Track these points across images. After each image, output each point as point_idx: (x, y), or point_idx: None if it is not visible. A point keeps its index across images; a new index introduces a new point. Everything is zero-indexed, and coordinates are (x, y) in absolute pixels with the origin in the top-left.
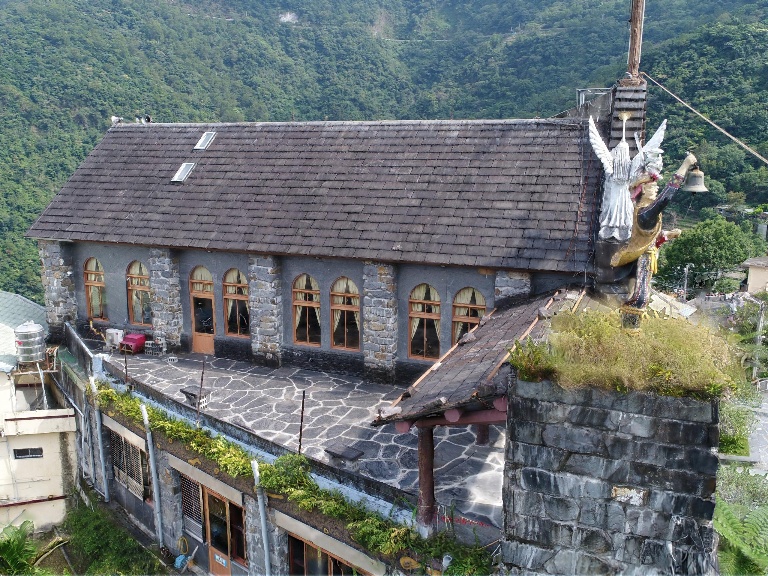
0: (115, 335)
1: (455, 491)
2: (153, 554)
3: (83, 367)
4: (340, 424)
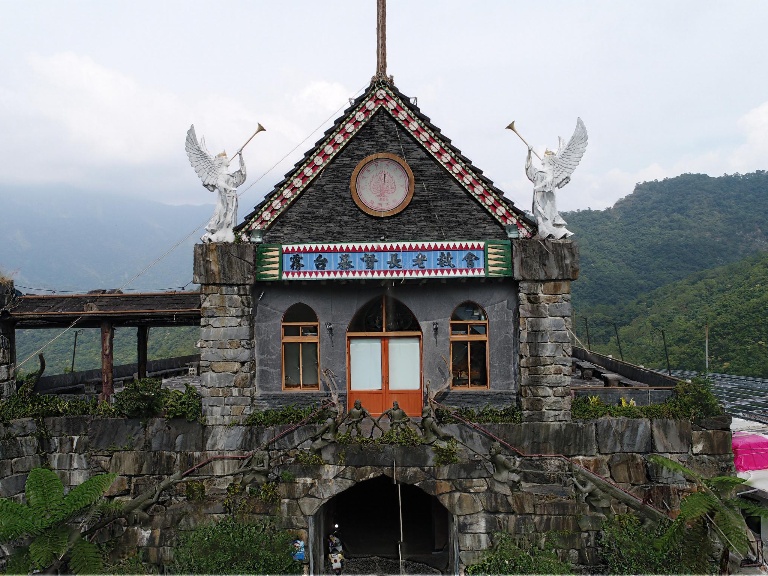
0: None
1: None
2: None
3: None
4: None
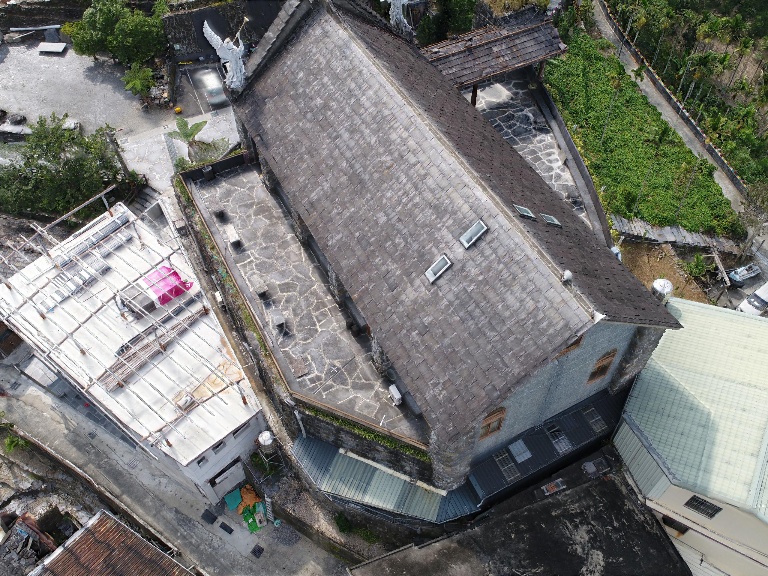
0: None
1: (511, 98)
2: None
3: None
4: None
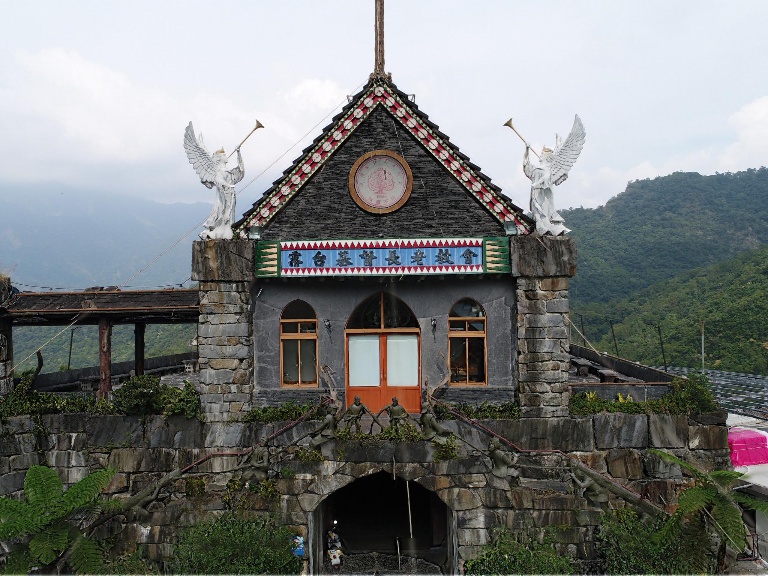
0: None
1: None
2: None
3: None
4: (171, 386)
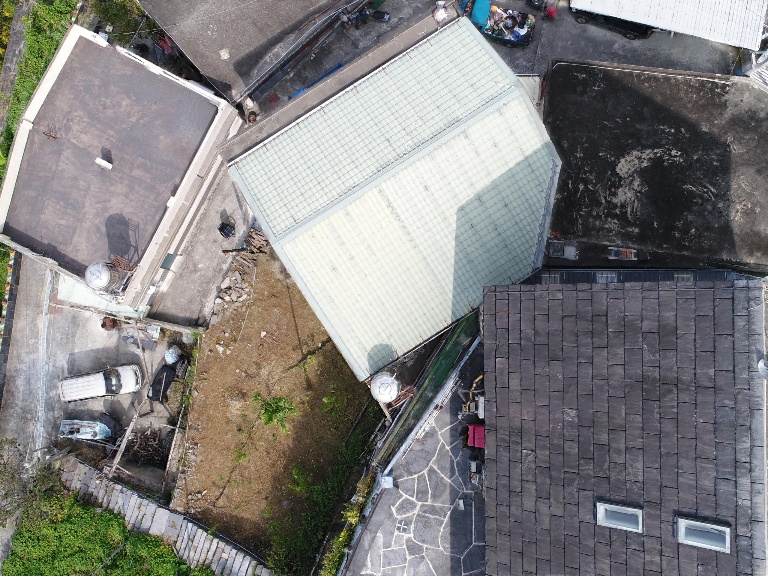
0: (479, 412)
1: None
2: (320, 556)
3: (415, 421)
4: None
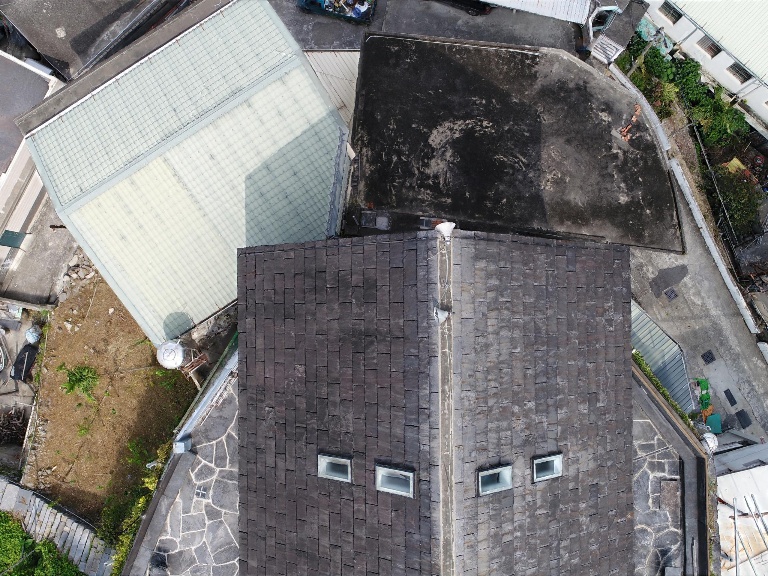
0: None
1: None
2: None
3: None
4: None
